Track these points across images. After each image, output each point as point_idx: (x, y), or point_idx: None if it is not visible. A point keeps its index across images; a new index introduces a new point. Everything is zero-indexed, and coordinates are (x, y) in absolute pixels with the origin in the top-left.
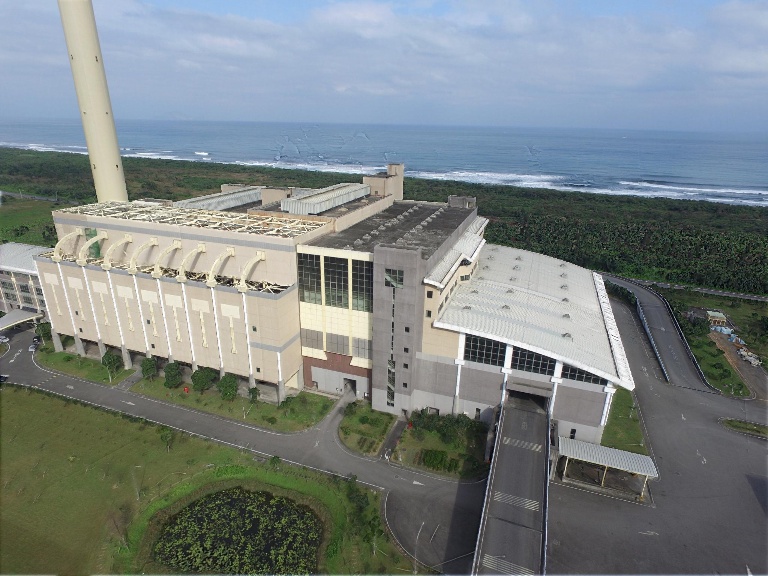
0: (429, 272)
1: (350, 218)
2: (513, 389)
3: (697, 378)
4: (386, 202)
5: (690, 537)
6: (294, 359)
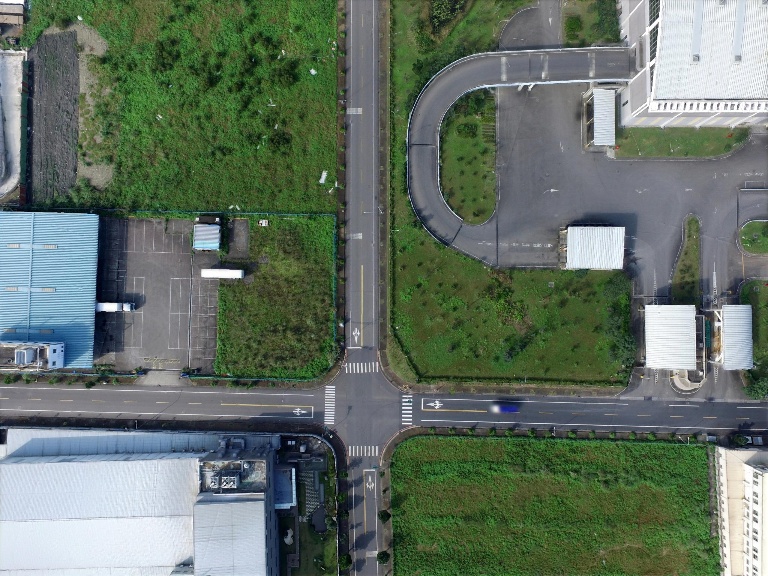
0: None
1: None
2: (636, 44)
3: (759, 216)
4: None
5: (567, 167)
6: None
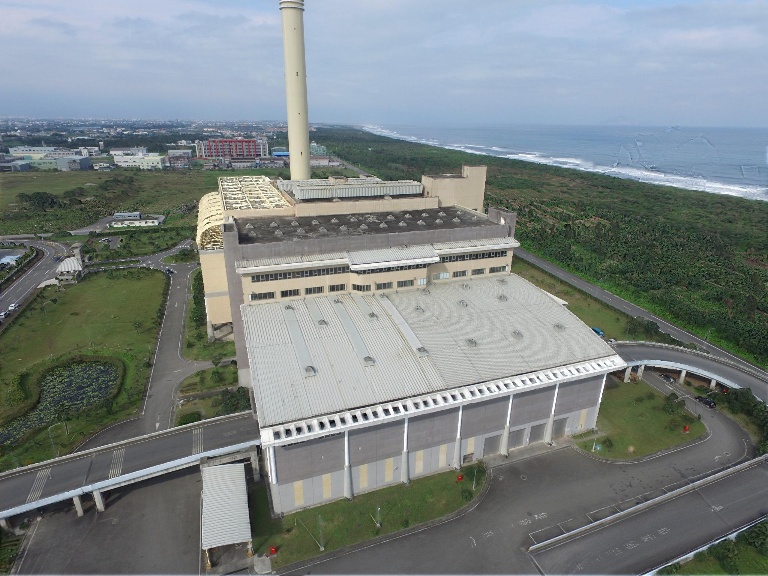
0: (252, 258)
1: (325, 208)
2: None
3: None
4: (420, 203)
5: None
6: (228, 310)
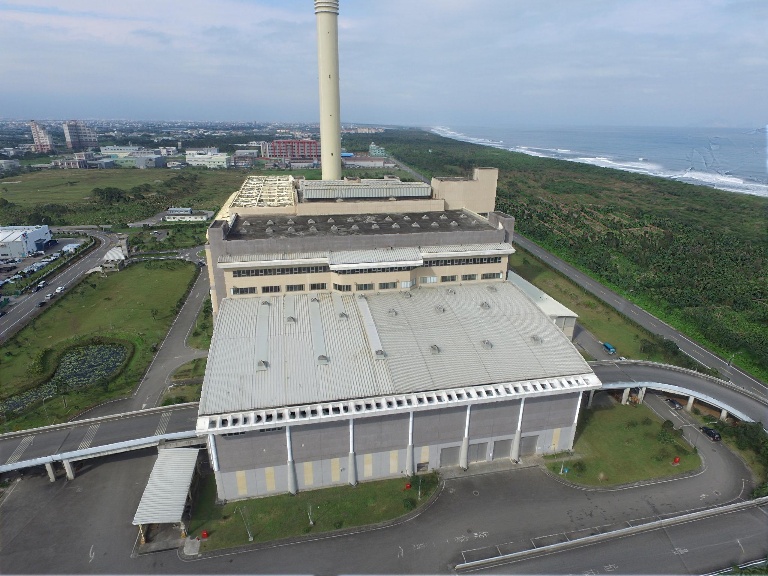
0: (236, 254)
1: (326, 207)
2: None
3: None
4: (424, 205)
5: None
6: None
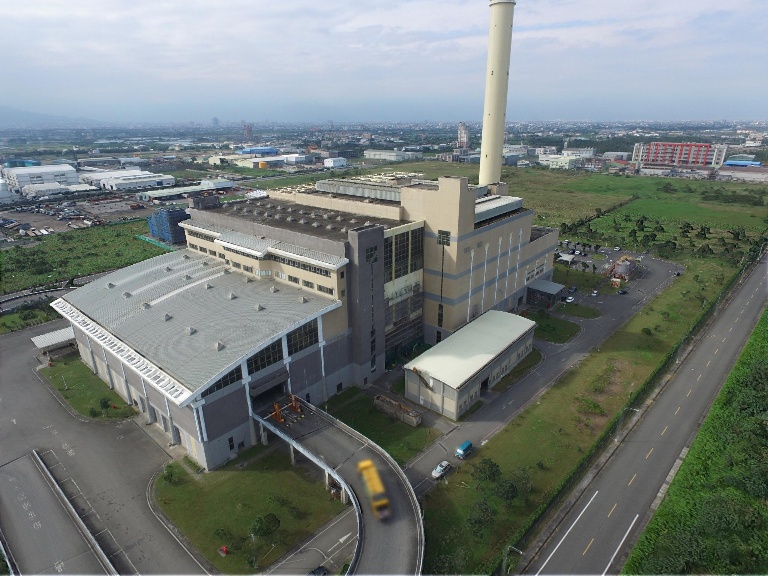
0: (196, 219)
1: (312, 199)
2: None
3: None
4: (382, 211)
5: None
6: None
